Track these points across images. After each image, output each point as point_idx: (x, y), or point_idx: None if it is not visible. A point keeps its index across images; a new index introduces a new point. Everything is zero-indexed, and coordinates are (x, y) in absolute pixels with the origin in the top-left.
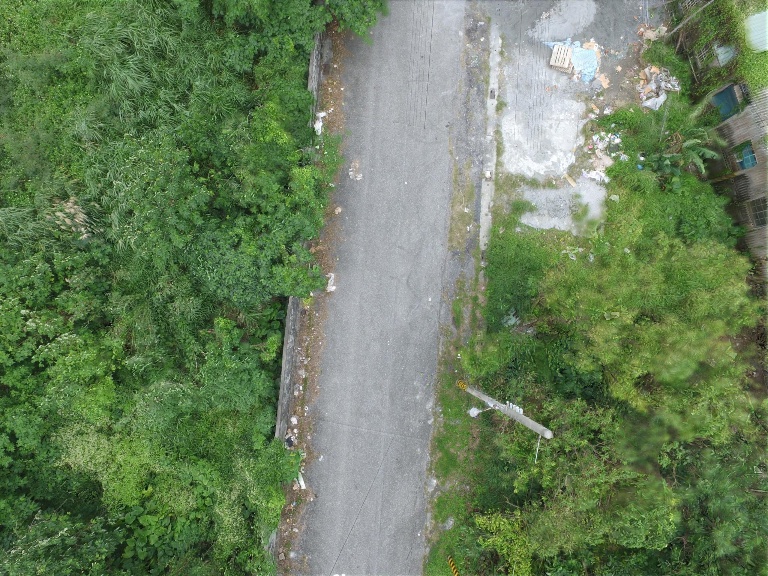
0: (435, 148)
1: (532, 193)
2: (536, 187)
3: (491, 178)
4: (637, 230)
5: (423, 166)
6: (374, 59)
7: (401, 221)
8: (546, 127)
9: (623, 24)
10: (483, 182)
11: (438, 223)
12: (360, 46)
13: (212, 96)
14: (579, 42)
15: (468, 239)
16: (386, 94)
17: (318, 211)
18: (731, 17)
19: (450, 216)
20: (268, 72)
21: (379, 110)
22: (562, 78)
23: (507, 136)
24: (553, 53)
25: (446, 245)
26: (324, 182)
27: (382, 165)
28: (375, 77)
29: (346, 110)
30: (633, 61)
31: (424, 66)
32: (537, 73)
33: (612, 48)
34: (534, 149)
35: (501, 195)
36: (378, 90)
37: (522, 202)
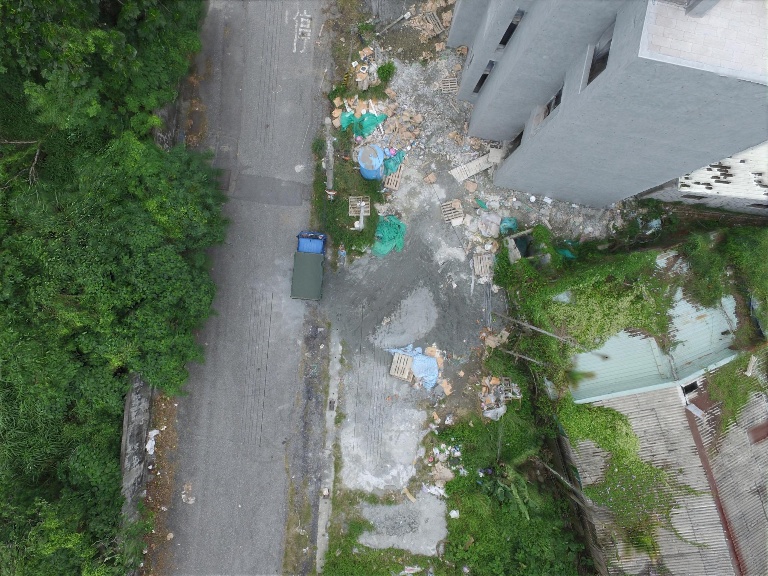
0: (271, 467)
1: (371, 510)
2: (374, 504)
3: (329, 496)
4: (472, 558)
5: (258, 487)
6: (209, 373)
7: (234, 548)
8: (386, 439)
9: (466, 326)
10: (321, 500)
11: (273, 548)
12: (195, 358)
13: (25, 447)
14: (420, 348)
15: (304, 562)
16: (221, 410)
17: (150, 537)
18: (554, 363)
19: (285, 539)
20: (75, 436)
21: (213, 428)
22: (403, 386)
23: (346, 450)
24: (393, 362)
25: (281, 571)
26: (156, 505)
27: (216, 487)
28: (210, 392)
29: (180, 428)
30: (476, 366)
31: (260, 379)
32: (377, 382)
33: (455, 352)
34: (373, 463)
35: (339, 514)
36: (213, 406)
37: (358, 525)
